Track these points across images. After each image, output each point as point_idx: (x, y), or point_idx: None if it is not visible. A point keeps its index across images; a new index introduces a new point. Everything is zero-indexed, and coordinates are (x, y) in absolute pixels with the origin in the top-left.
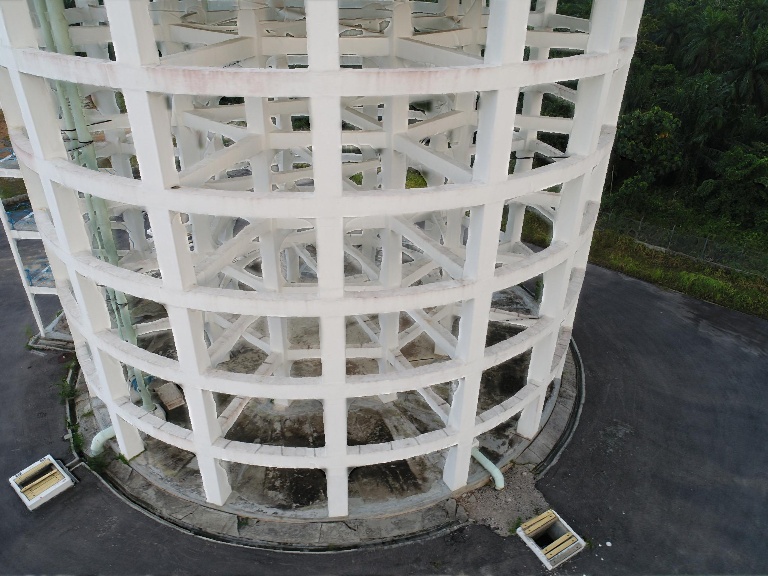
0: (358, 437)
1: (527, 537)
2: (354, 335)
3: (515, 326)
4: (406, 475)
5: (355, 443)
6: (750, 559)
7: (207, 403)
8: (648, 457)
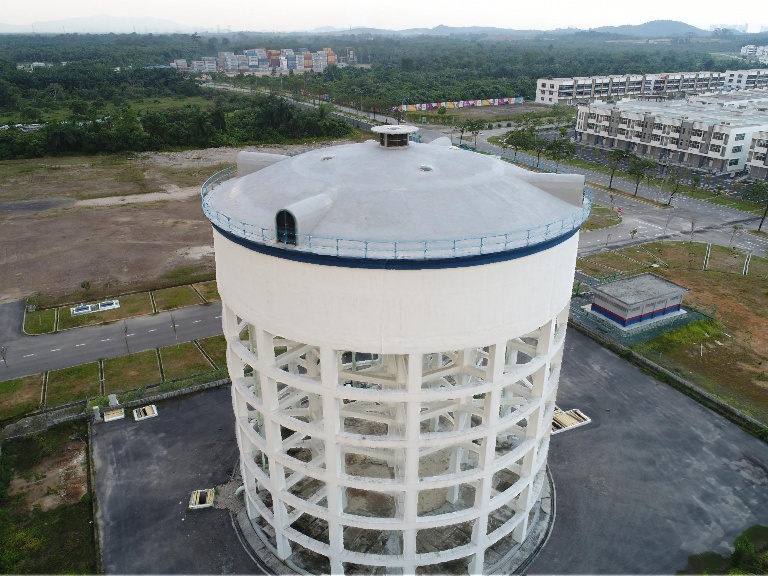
0: (299, 453)
1: (208, 489)
2: (379, 471)
3: (346, 562)
4: (266, 461)
5: (296, 452)
6: (129, 569)
7: (289, 368)
8: (202, 570)
